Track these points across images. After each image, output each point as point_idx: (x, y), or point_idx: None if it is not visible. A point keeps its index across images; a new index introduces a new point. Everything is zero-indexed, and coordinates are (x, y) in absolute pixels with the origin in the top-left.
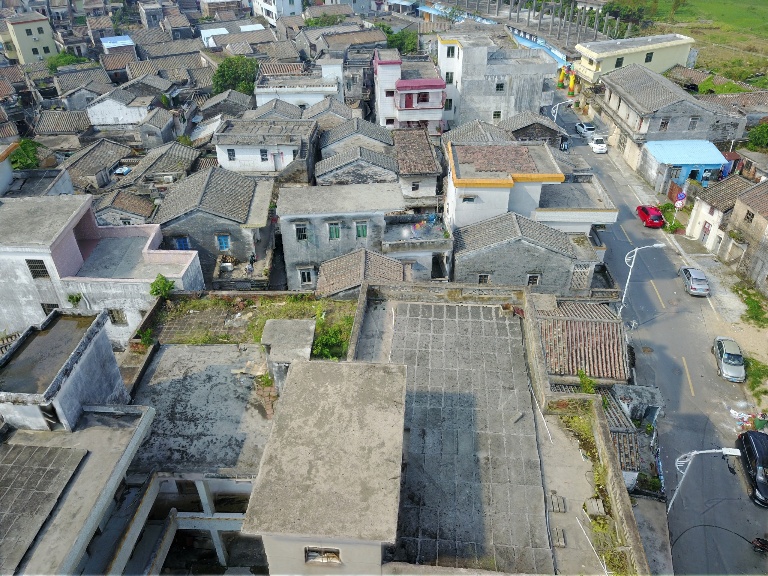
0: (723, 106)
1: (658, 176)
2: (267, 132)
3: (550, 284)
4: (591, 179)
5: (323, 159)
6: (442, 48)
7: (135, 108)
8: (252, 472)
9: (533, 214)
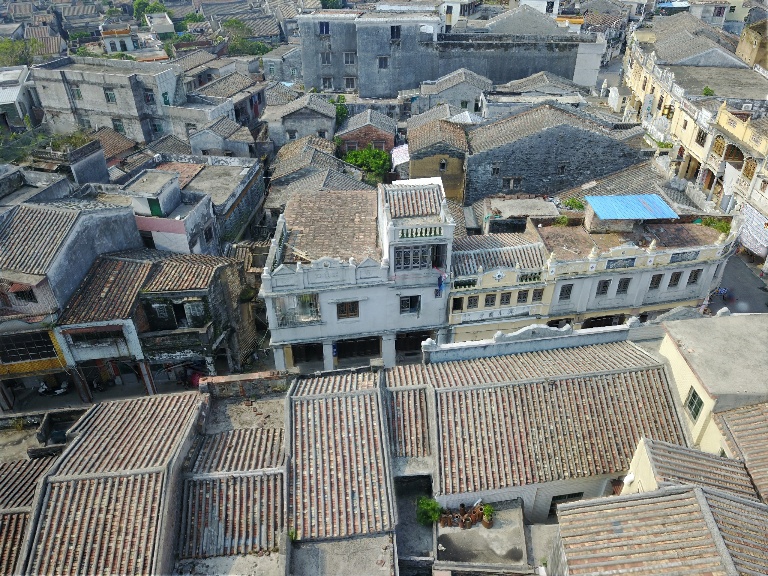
0: None
1: None
2: None
3: None
4: None
5: None
6: None
7: None
8: (504, 11)
9: None
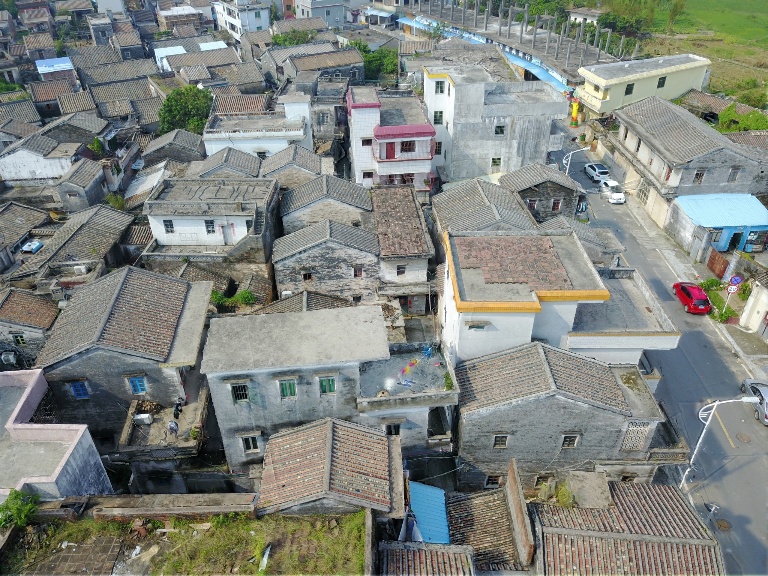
0: (763, 150)
1: (694, 240)
2: (214, 196)
3: (593, 445)
4: (632, 274)
5: (285, 229)
6: (429, 83)
7: (55, 159)
8: None
9: (564, 339)
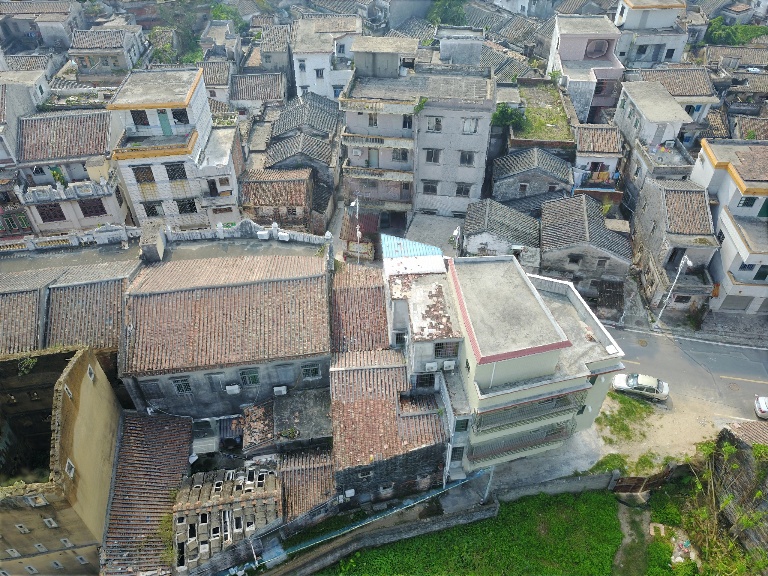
0: None
1: None
2: None
3: (655, 241)
4: None
5: None
6: None
7: None
8: None
9: None
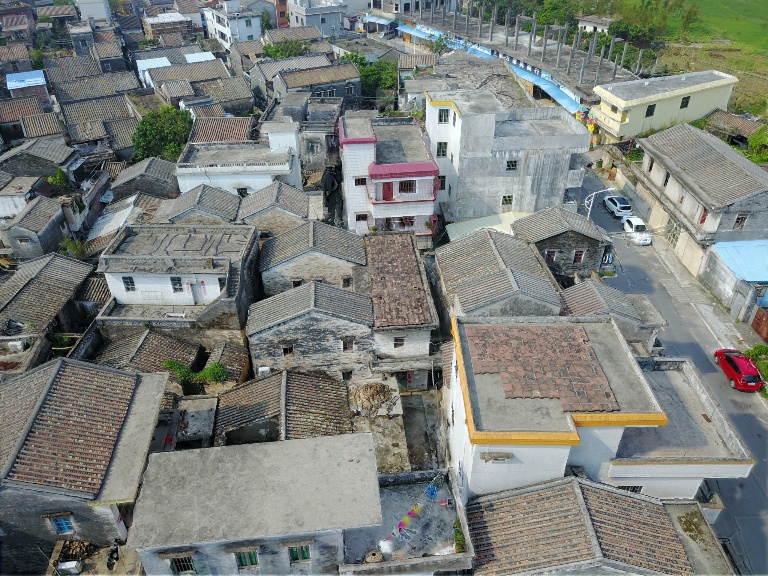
0: None
1: (736, 296)
2: (182, 247)
3: None
4: (681, 365)
5: (264, 287)
6: (432, 111)
7: (7, 197)
8: None
9: (605, 466)
